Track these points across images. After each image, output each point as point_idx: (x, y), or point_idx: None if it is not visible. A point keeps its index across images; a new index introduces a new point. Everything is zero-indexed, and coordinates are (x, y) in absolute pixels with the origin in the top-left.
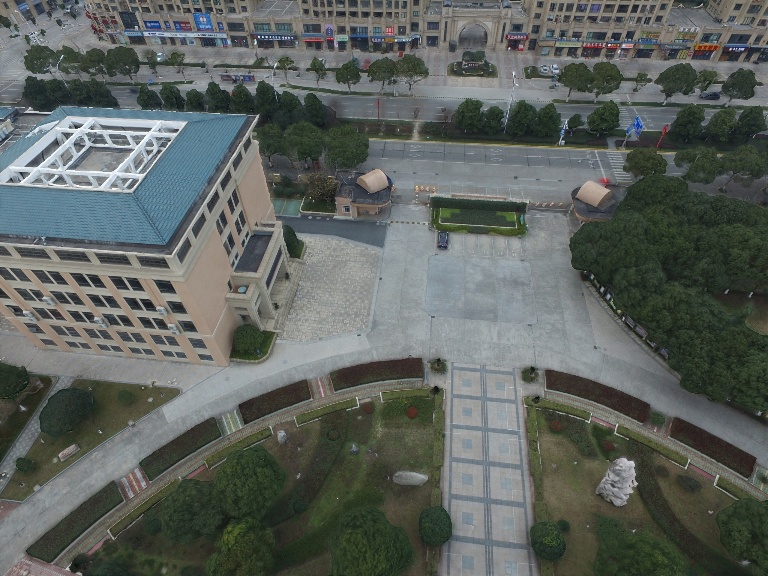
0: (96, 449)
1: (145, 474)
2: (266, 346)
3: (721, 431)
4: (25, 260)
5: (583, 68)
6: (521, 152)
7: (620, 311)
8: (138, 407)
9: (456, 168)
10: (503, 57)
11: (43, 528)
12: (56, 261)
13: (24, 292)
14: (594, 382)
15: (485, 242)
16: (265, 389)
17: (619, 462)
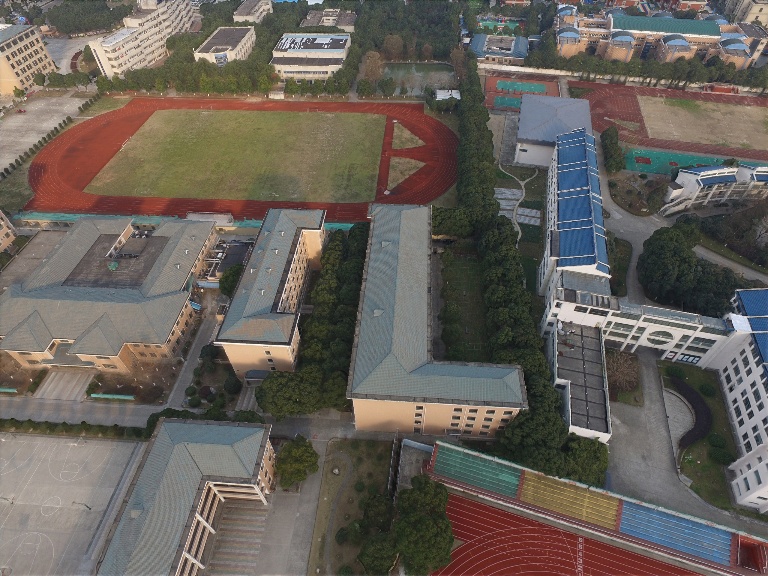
0: None
1: None
2: None
3: None
4: (15, 46)
5: None
6: None
7: (84, 34)
8: None
9: None
10: None
11: None
12: None
13: None
14: None
15: (46, 47)
16: None
17: None
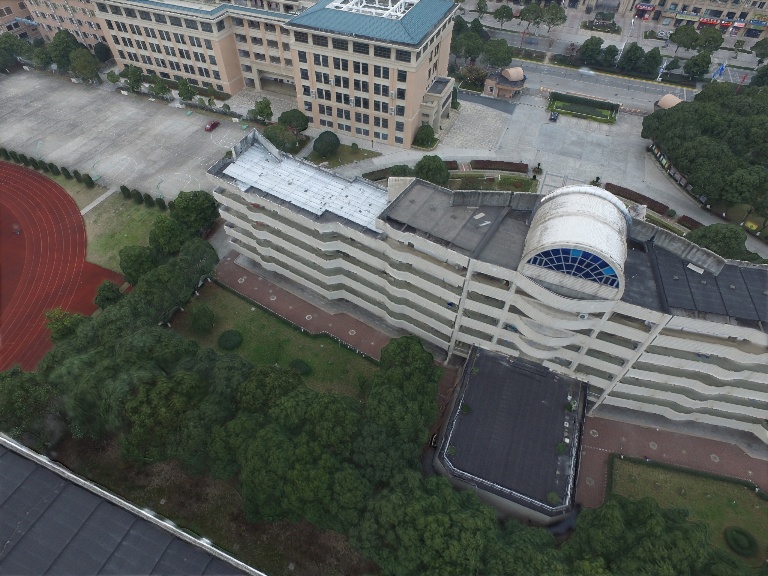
0: (337, 167)
1: None
2: (433, 144)
3: None
4: (334, 50)
5: (691, 29)
6: (625, 81)
7: (667, 165)
8: (359, 156)
9: (573, 83)
10: (629, 22)
11: None
12: (350, 52)
13: (318, 76)
14: (636, 192)
15: (583, 123)
16: None
17: (638, 205)
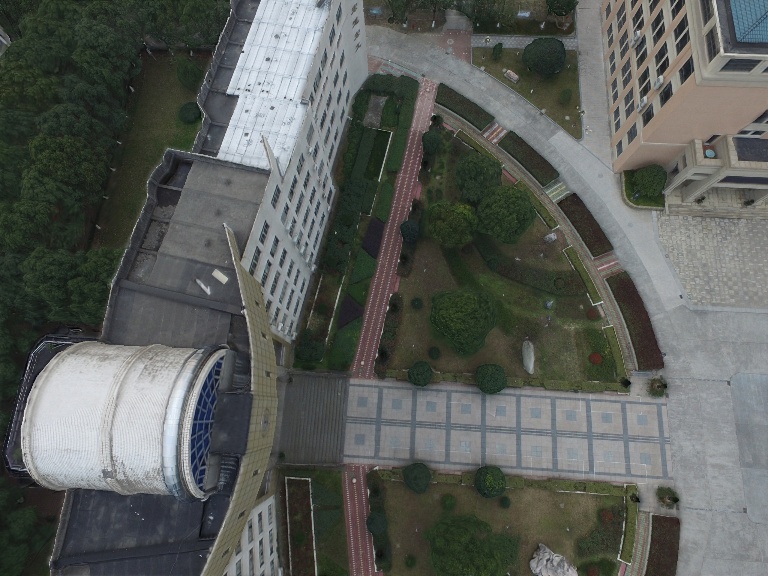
0: (517, 95)
1: (503, 138)
2: (645, 202)
3: None
4: None
5: None
6: None
7: None
8: (559, 111)
9: None
10: None
11: (456, 86)
12: None
13: None
14: None
15: None
16: (596, 213)
17: (573, 570)
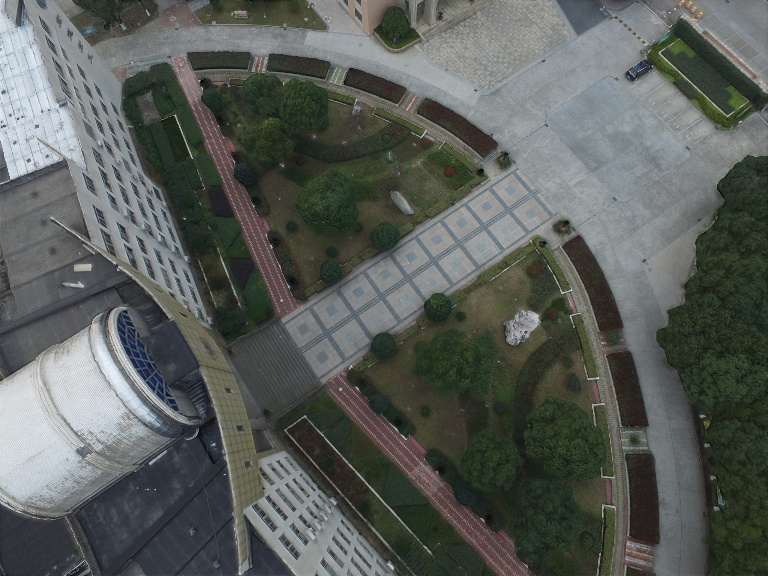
0: (256, 26)
1: (268, 64)
2: (405, 42)
3: (652, 393)
4: None
5: None
6: None
7: None
8: (296, 18)
9: (758, 9)
10: None
11: (203, 49)
12: None
13: None
14: (603, 275)
15: (677, 104)
16: (376, 73)
17: (530, 312)
